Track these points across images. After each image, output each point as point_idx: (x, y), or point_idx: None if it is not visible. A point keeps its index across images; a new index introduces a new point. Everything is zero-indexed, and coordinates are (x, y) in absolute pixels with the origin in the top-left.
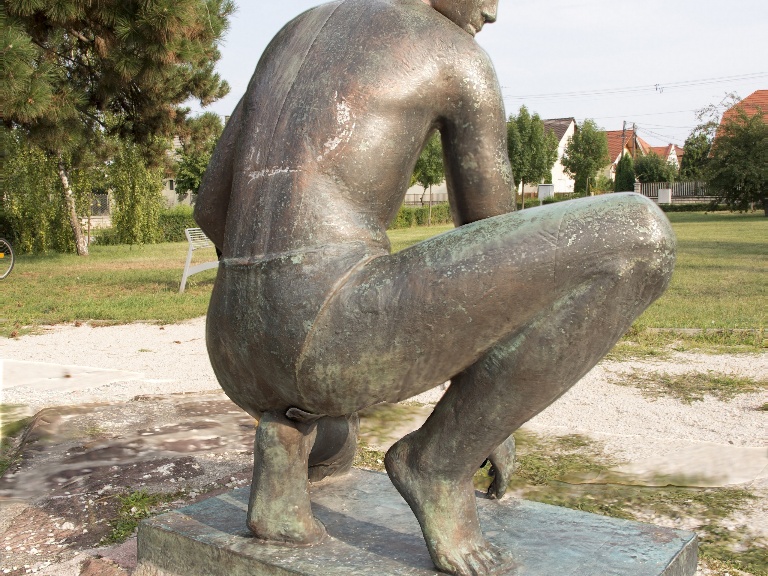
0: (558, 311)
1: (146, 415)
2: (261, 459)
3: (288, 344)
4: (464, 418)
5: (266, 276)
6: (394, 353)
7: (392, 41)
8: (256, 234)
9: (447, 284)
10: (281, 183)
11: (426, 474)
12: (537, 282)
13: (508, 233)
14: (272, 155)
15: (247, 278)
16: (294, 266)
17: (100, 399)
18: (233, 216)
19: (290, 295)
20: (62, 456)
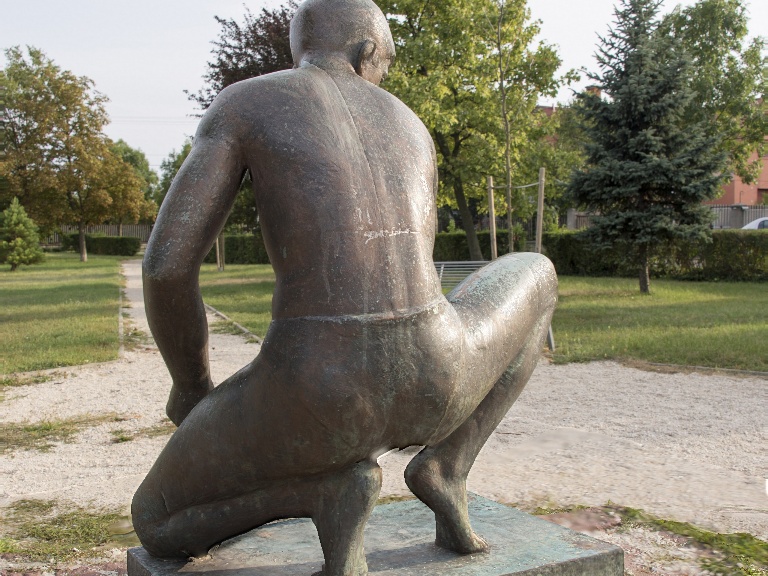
0: (537, 334)
1: None
2: (364, 507)
3: (444, 384)
4: (485, 425)
5: (417, 327)
6: (492, 378)
7: (417, 126)
8: (393, 290)
9: (511, 321)
10: (406, 243)
11: (457, 479)
12: (534, 315)
13: None
14: (386, 217)
15: (395, 331)
16: (436, 316)
17: None
18: (354, 274)
19: (440, 341)
20: None
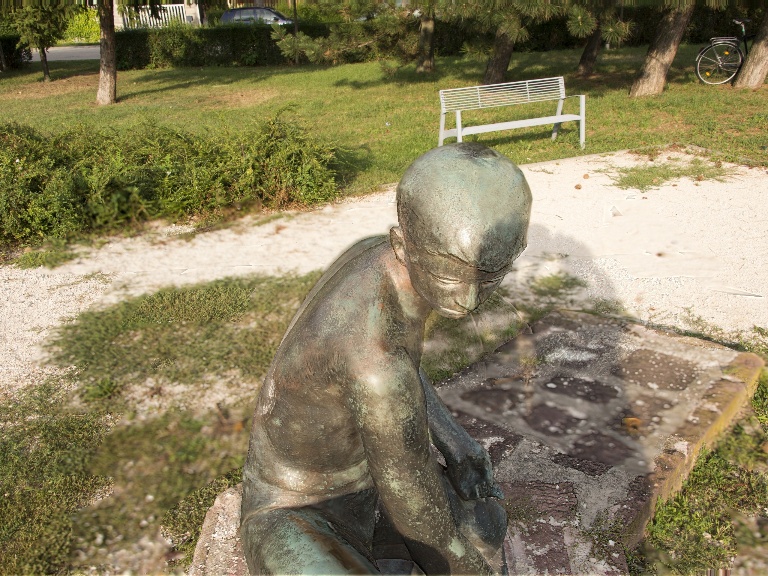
0: None
1: (597, 354)
2: None
3: None
4: None
5: None
6: None
7: None
8: None
9: None
10: None
11: None
12: None
13: (287, 575)
14: None
15: None
16: None
17: (644, 296)
18: None
19: None
20: (477, 384)
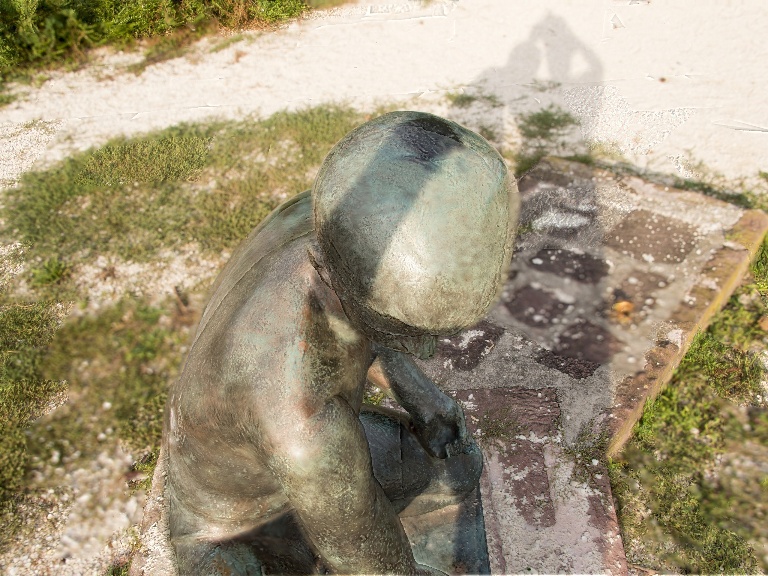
0: None
1: (588, 217)
2: None
3: None
4: None
5: None
6: None
7: (215, 381)
8: None
9: None
10: None
11: None
12: None
13: None
14: None
15: None
16: None
17: (644, 134)
18: None
19: None
20: None
